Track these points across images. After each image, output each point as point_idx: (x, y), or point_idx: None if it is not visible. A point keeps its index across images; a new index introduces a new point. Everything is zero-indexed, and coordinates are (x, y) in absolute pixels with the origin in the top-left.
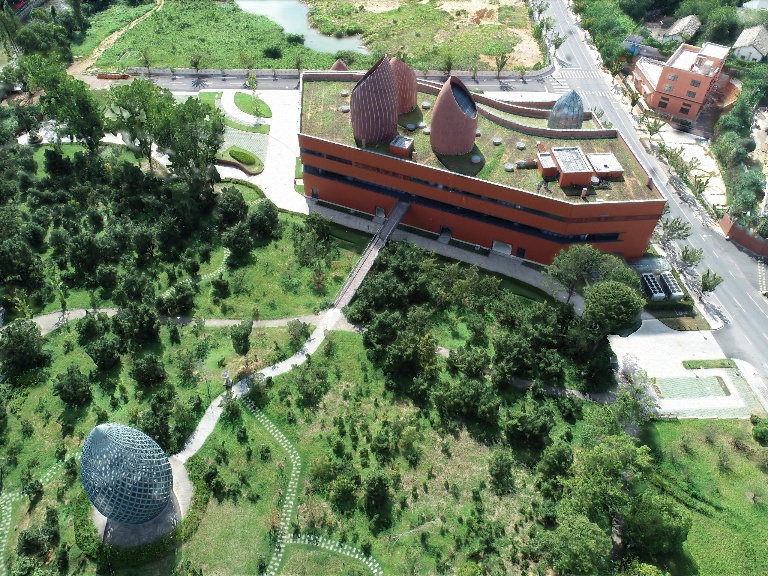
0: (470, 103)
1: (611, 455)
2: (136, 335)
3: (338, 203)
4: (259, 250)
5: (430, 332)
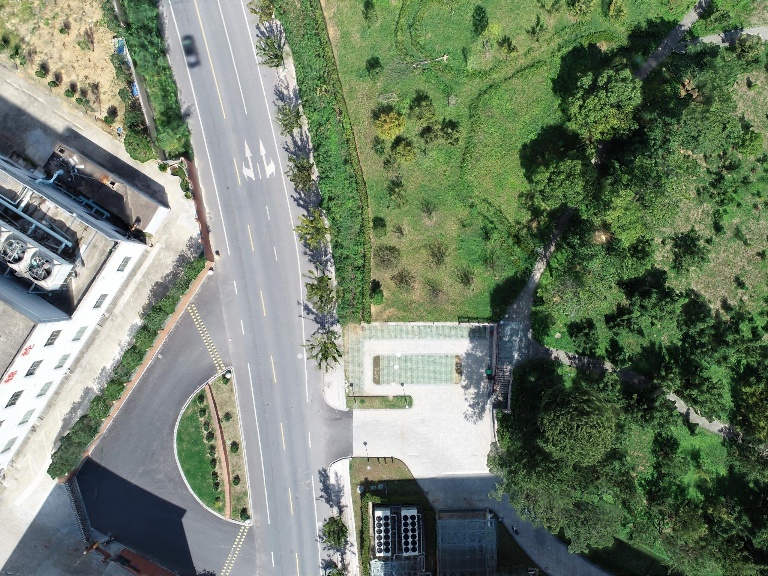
0: None
1: None
2: None
3: None
4: None
5: None
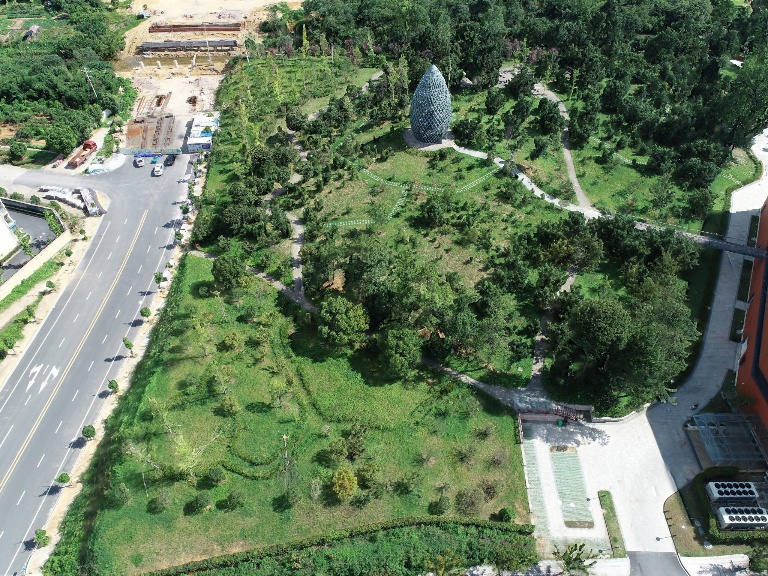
0: None
1: (425, 263)
2: None
3: (760, 227)
4: None
5: None
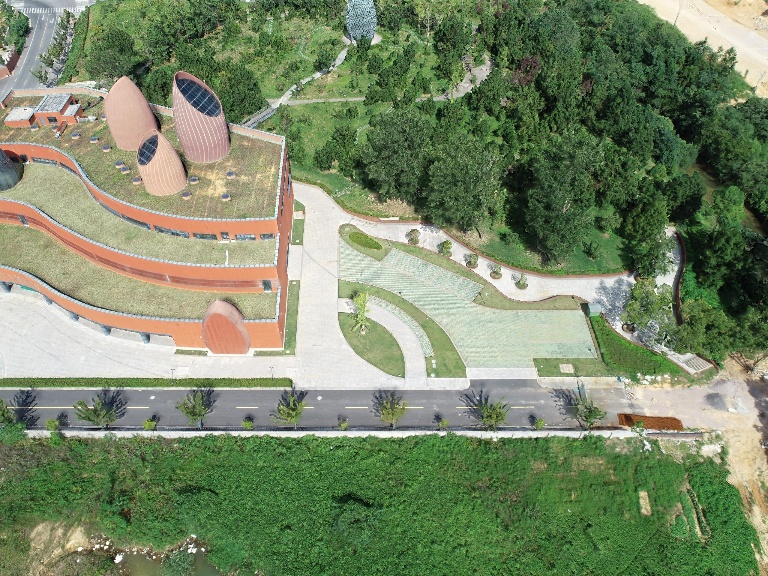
0: None
1: None
2: None
3: None
4: None
5: (220, 74)
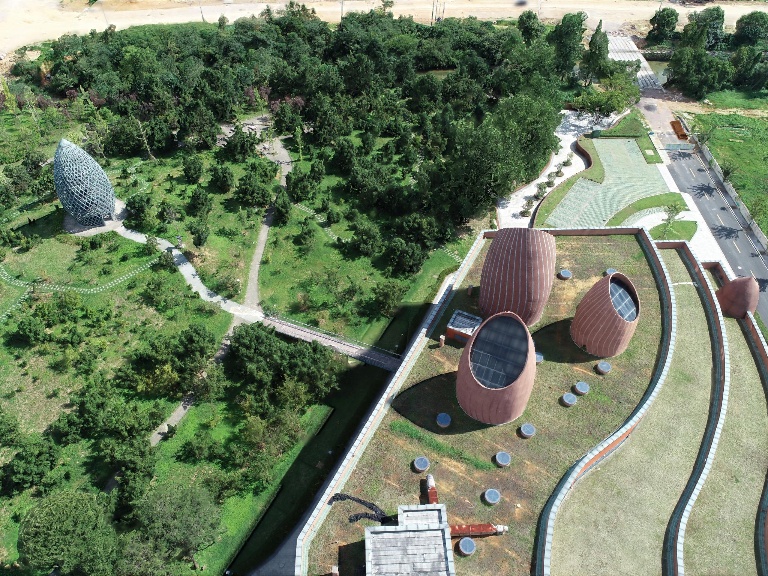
0: (512, 374)
1: None
2: None
3: None
4: (366, 262)
5: None
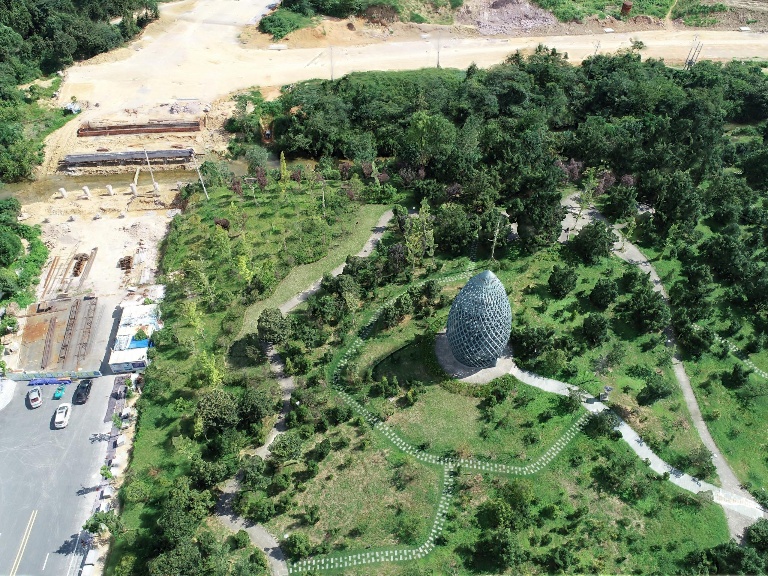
0: None
1: None
2: (634, 312)
3: None
4: None
5: None
